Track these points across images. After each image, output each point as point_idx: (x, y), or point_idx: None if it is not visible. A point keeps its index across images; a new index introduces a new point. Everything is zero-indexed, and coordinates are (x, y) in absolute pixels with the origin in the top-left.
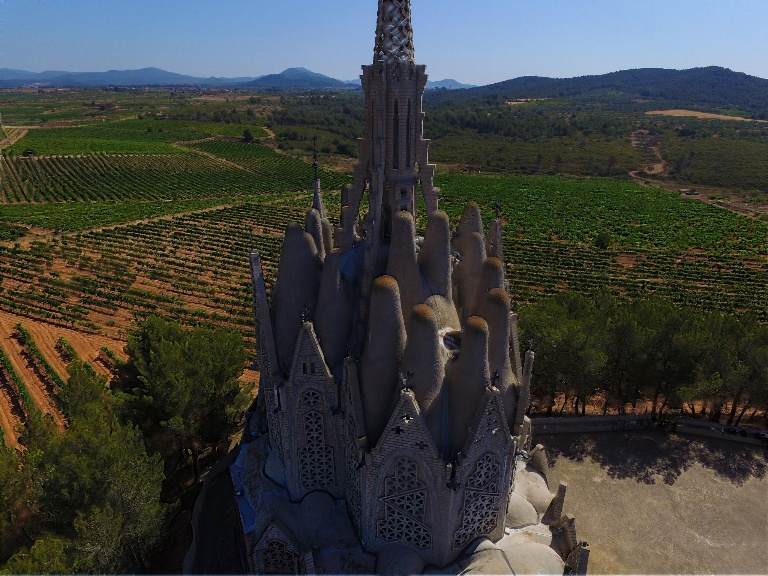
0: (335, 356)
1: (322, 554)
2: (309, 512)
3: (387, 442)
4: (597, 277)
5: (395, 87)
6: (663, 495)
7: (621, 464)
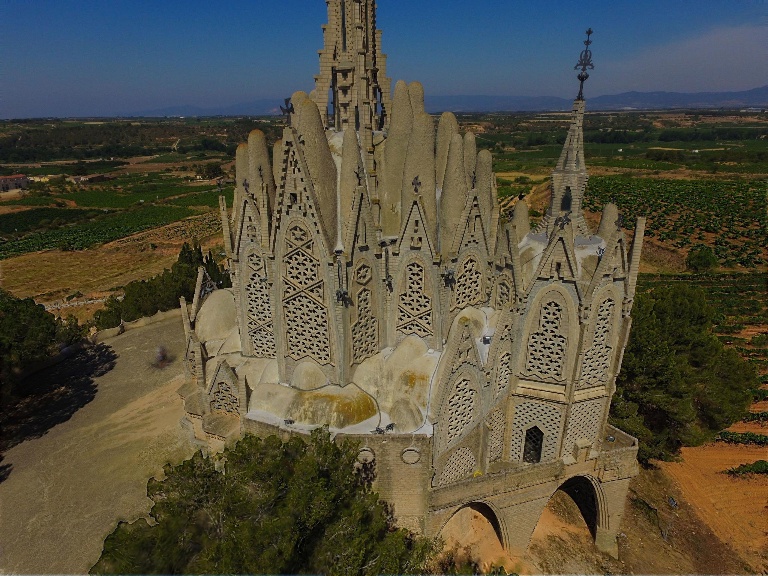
0: None
1: None
2: None
3: None
4: None
5: None
6: None
7: None
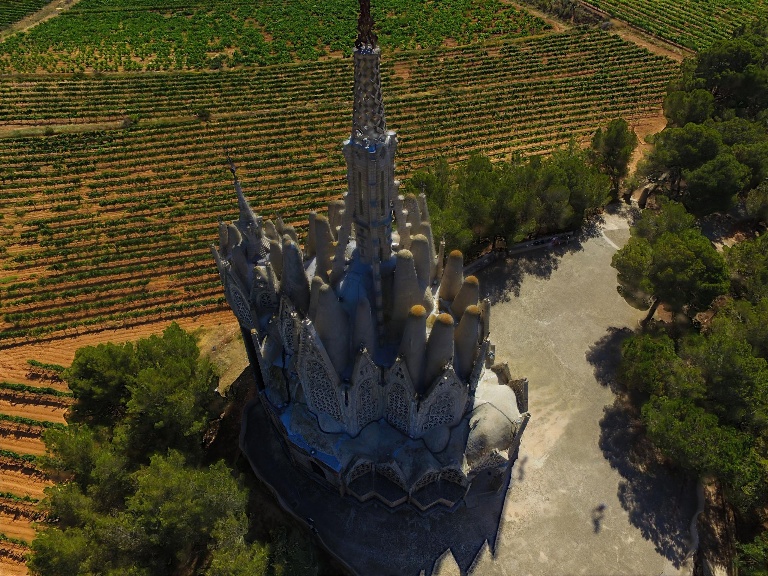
0: (373, 354)
1: (394, 456)
2: (370, 438)
3: (433, 392)
4: (390, 101)
5: (381, 164)
6: (517, 305)
7: (490, 295)
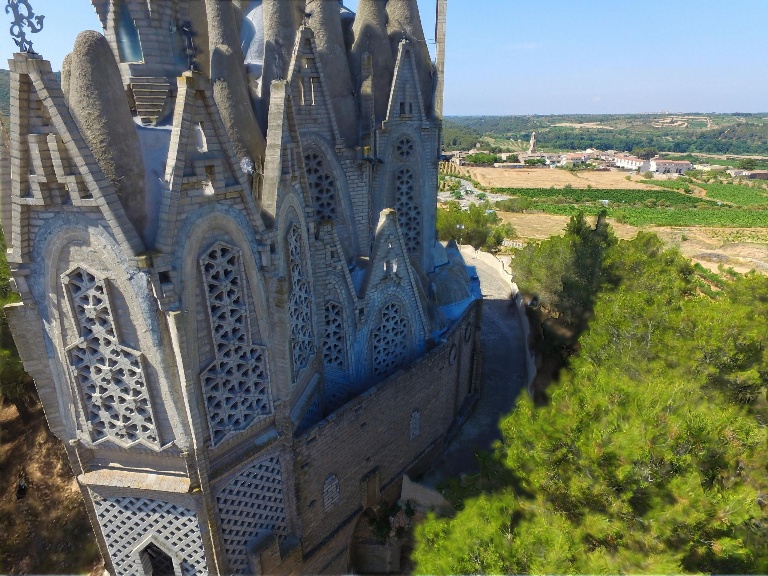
0: None
1: None
2: None
3: None
4: None
5: None
6: None
7: None
